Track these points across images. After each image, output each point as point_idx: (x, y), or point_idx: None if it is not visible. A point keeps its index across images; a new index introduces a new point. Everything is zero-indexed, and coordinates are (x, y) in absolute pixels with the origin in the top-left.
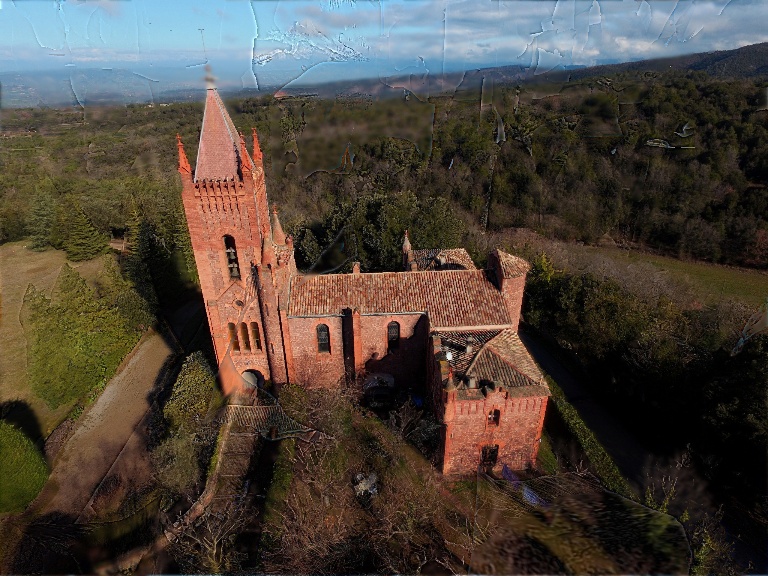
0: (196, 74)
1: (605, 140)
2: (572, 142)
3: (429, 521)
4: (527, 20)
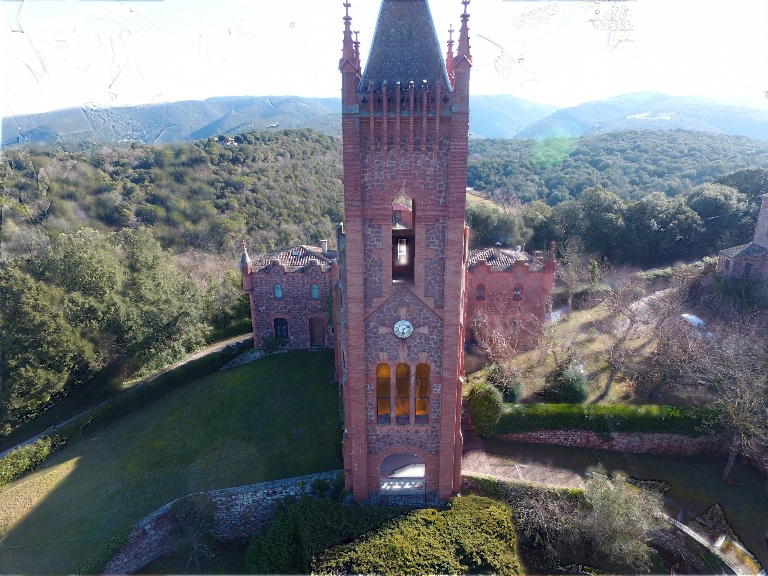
0: None
1: (180, 156)
2: (151, 160)
3: (589, 354)
4: (2, 10)
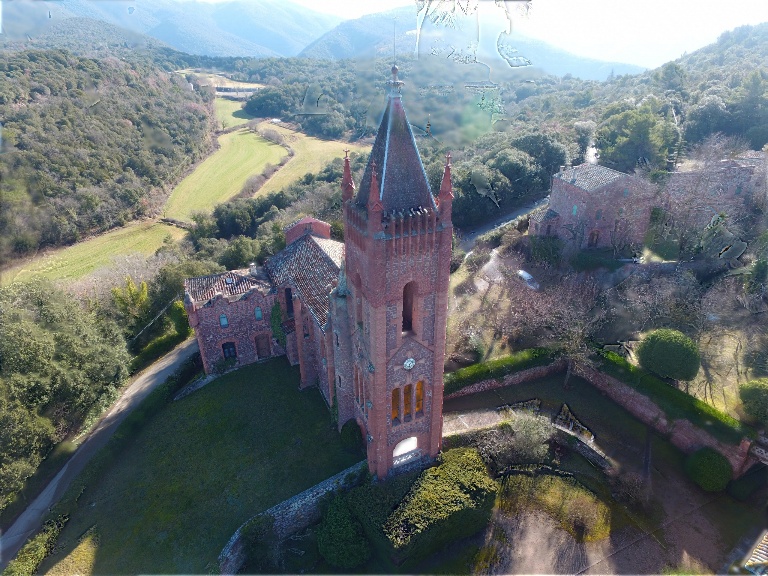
0: (509, 73)
1: None
2: None
3: None
4: None
